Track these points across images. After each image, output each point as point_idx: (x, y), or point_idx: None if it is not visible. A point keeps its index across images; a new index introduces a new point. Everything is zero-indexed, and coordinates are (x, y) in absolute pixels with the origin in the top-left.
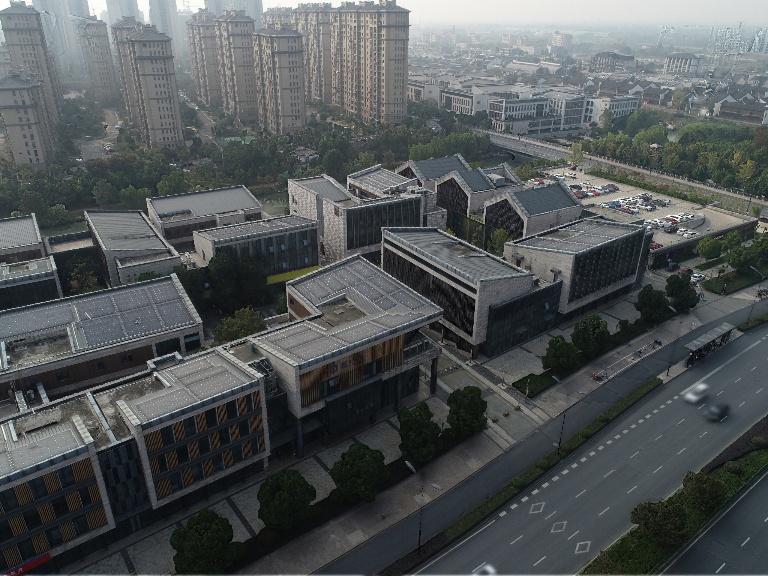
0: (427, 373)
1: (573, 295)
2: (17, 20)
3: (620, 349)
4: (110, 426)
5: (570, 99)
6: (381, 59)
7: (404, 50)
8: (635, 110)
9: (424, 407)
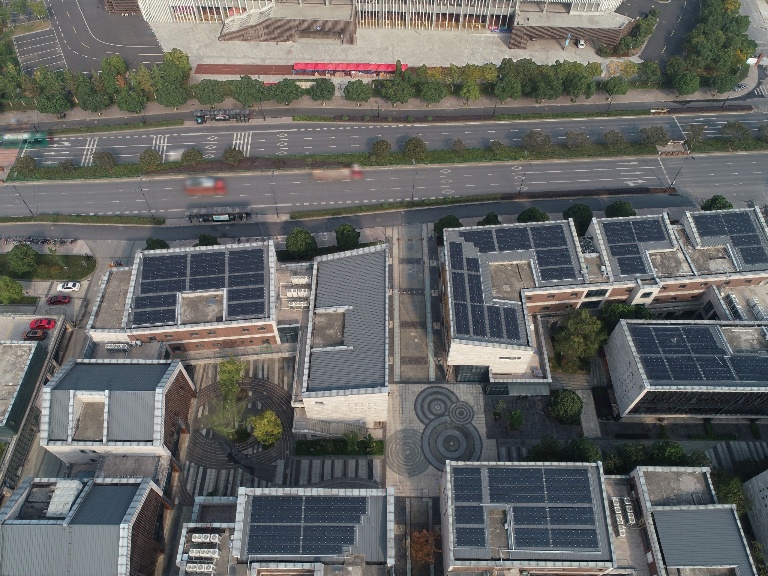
0: (429, 297)
1: None
2: None
3: None
4: (678, 242)
5: None
6: None
7: None
8: None
9: None
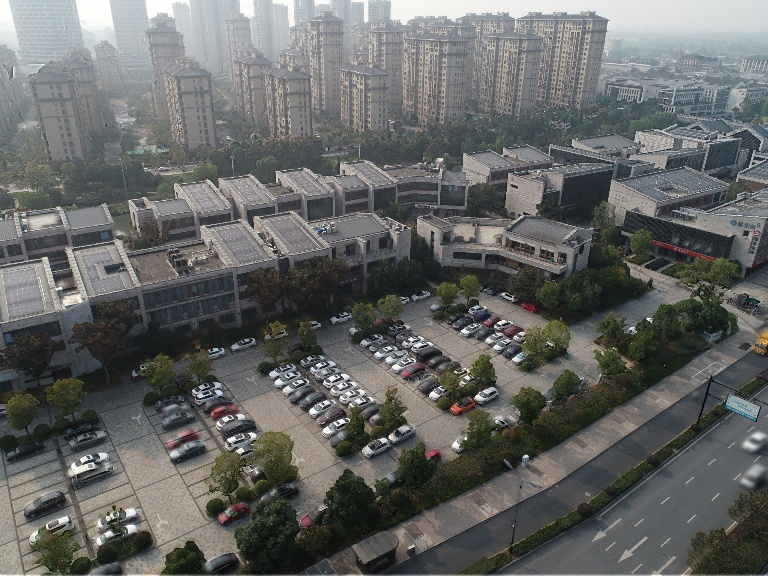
0: None
1: None
2: (333, 26)
3: None
4: None
5: (720, 89)
6: (582, 57)
7: (601, 50)
8: (762, 99)
9: None
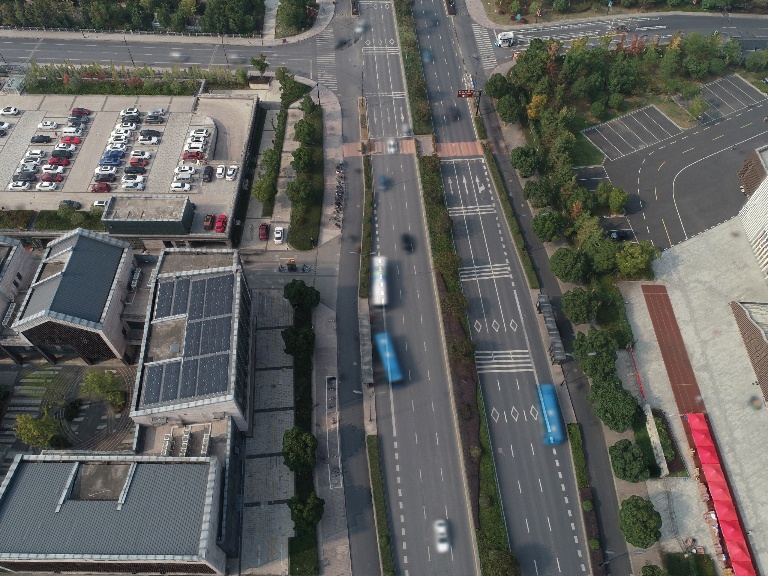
0: None
1: (243, 408)
2: None
3: (315, 418)
4: None
5: None
6: None
7: None
8: None
9: None
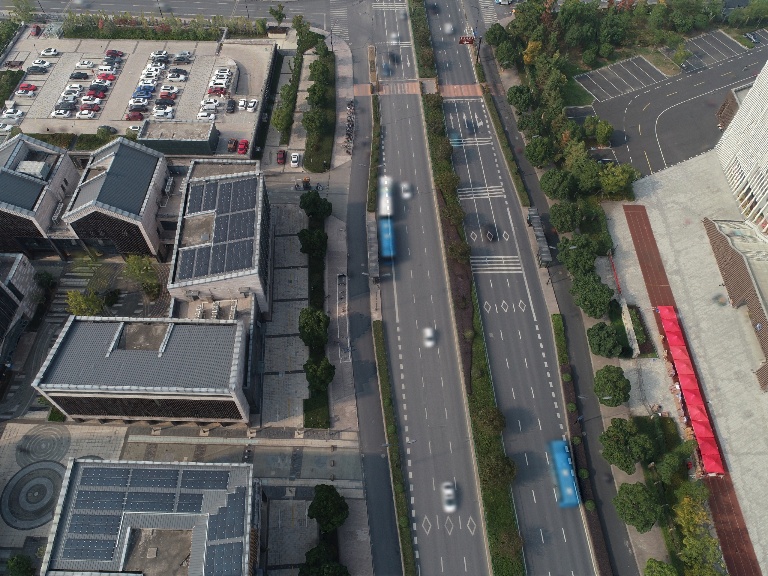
0: None
1: (264, 291)
2: None
3: (327, 307)
4: None
5: None
6: None
7: None
8: None
9: (317, 554)
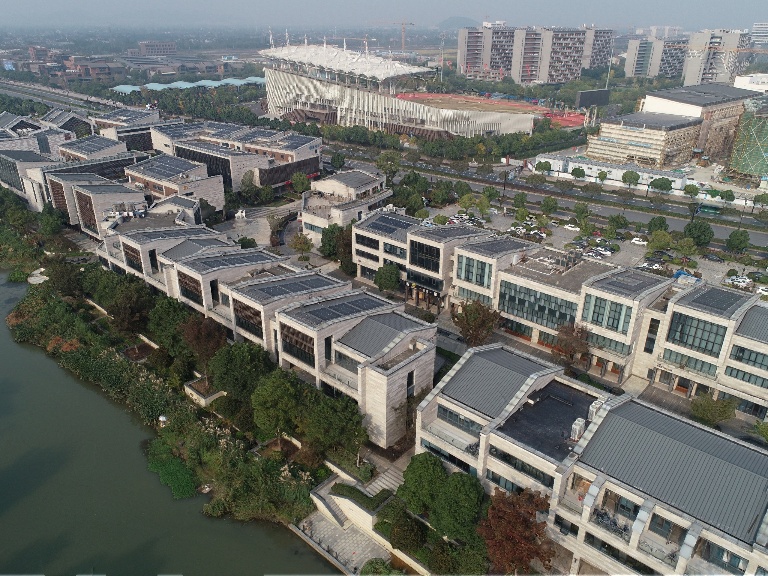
0: None
1: None
2: None
3: None
4: None
5: None
6: None
7: None
8: None
9: None
